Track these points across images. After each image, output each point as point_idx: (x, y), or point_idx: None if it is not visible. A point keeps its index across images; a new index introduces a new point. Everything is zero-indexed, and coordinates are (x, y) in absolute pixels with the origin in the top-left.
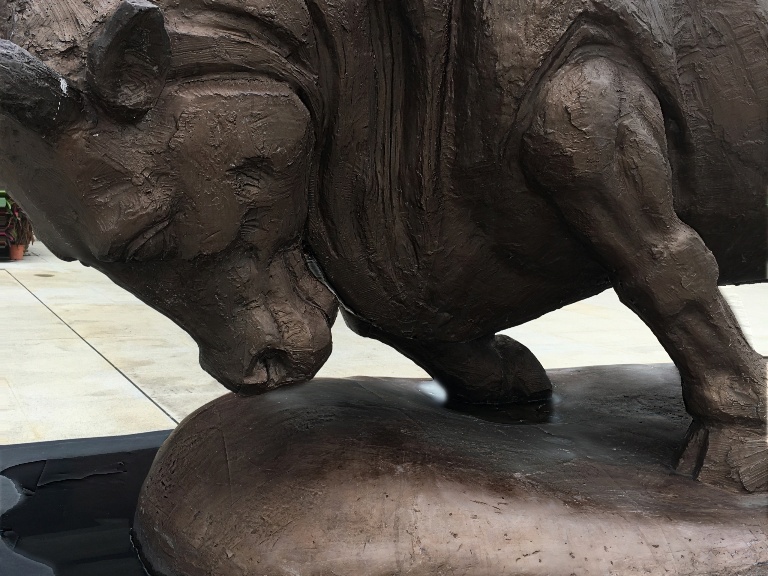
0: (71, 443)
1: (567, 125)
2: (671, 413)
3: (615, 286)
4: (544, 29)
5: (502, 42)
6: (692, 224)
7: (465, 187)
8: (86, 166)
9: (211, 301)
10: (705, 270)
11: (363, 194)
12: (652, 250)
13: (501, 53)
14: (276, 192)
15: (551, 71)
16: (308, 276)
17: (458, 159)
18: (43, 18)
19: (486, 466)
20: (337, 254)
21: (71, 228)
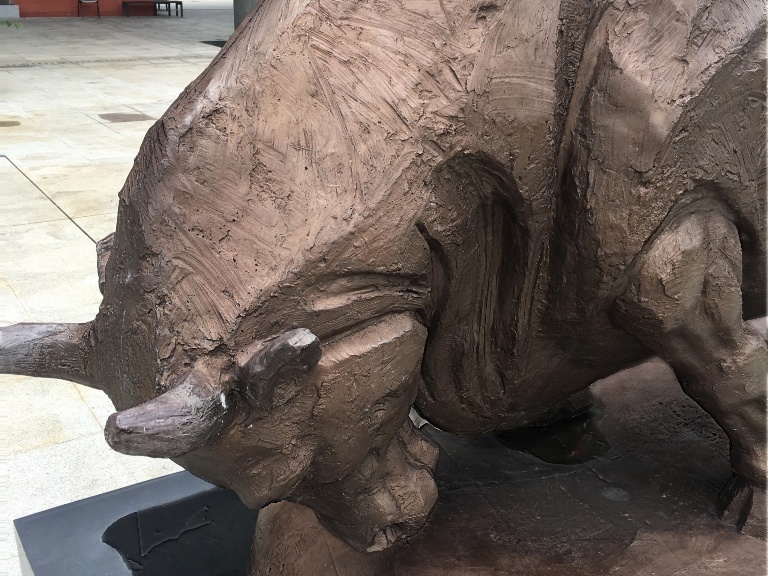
0: (152, 483)
1: (661, 294)
2: (705, 430)
3: (680, 382)
4: (647, 217)
5: (605, 231)
6: (748, 299)
7: (553, 330)
8: (242, 453)
9: (338, 497)
10: (766, 372)
11: (461, 355)
12: (721, 365)
13: (604, 241)
14: (398, 405)
15: (648, 245)
16: (414, 438)
17: (549, 312)
18: (185, 312)
19: (572, 575)
20: (433, 399)
21: (221, 481)
